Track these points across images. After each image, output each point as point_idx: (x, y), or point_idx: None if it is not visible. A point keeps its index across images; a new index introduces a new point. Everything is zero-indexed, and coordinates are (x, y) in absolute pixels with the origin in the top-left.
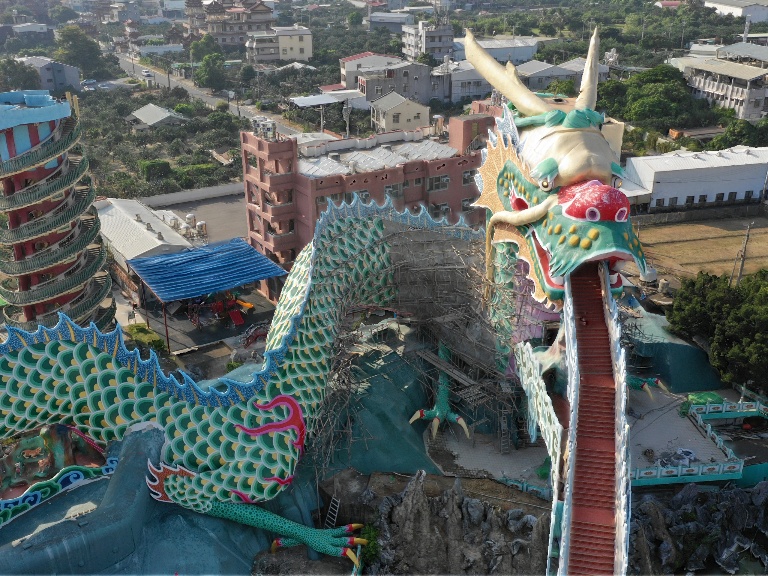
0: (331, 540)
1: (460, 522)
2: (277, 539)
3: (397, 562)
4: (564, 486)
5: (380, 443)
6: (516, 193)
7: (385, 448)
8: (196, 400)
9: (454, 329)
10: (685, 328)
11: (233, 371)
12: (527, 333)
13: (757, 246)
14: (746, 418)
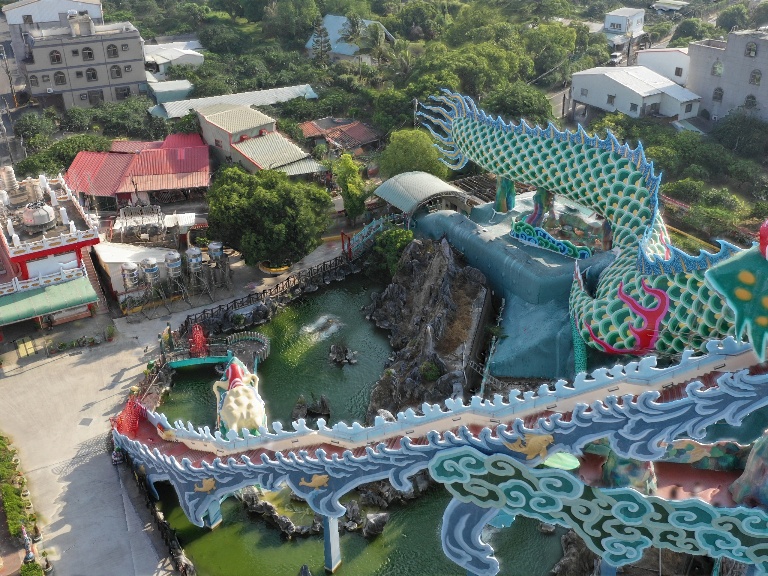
0: None
1: None
2: None
3: None
4: None
5: (727, 428)
6: None
7: (724, 435)
8: None
9: None
10: None
11: None
12: None
13: None
14: None
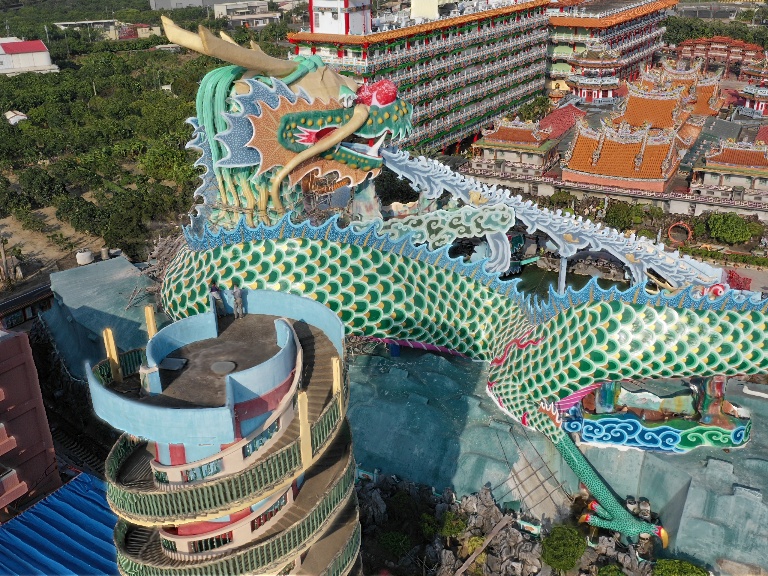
0: None
1: None
2: None
3: None
4: None
5: None
6: (315, 129)
7: None
8: None
9: None
10: None
11: (381, 411)
12: None
13: None
14: None
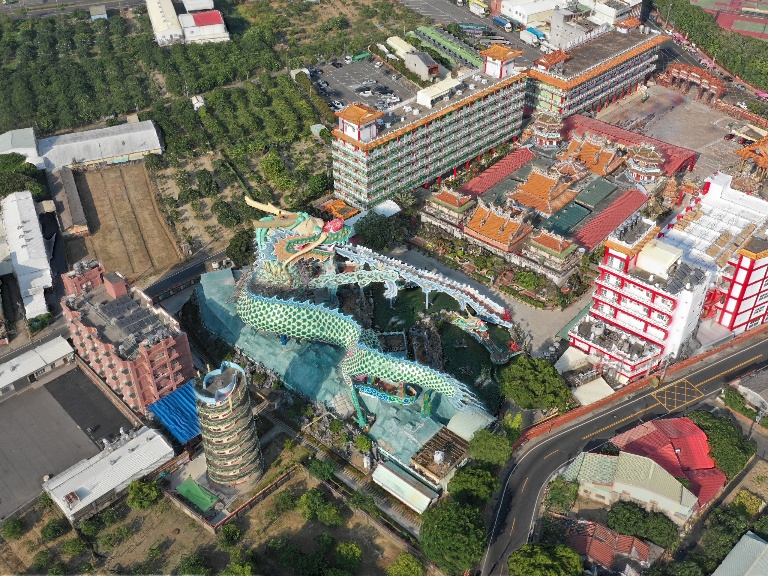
0: None
1: None
2: None
3: None
4: None
5: None
6: None
7: None
8: None
9: None
10: None
11: (302, 367)
12: None
13: (114, 248)
14: None
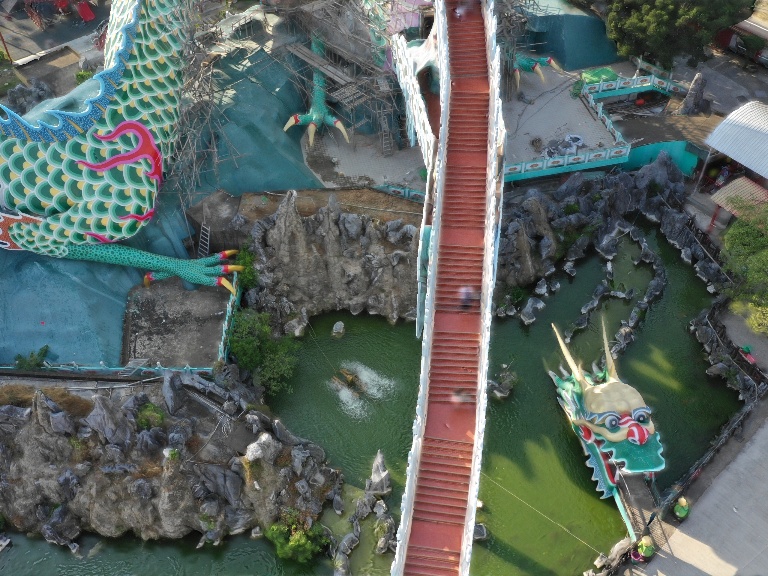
0: (204, 270)
1: (338, 239)
2: (148, 274)
3: (276, 284)
4: (433, 208)
5: (251, 158)
6: None
7: (257, 163)
8: (27, 136)
9: (324, 19)
10: None
11: (79, 86)
12: (403, 22)
13: None
14: (640, 93)
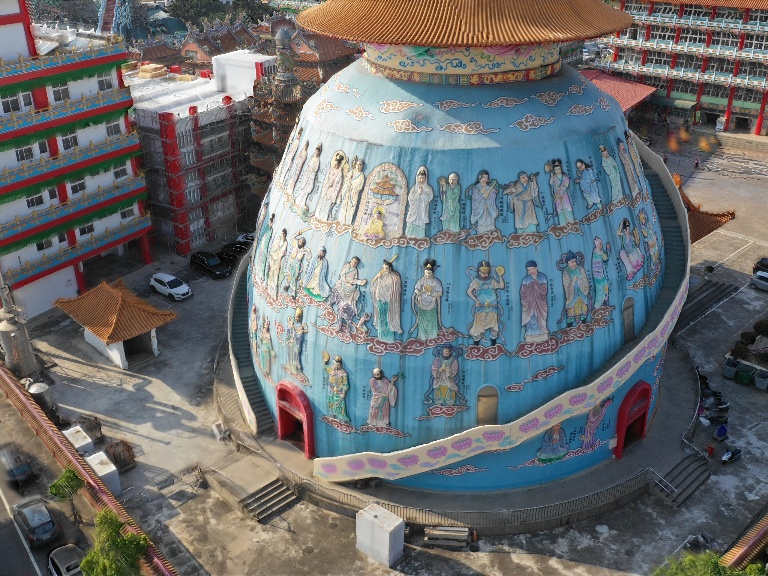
0: None
1: None
2: None
3: None
4: None
5: None
6: None
7: None
8: None
9: (83, 8)
10: (176, 14)
11: None
12: None
13: None
14: None
